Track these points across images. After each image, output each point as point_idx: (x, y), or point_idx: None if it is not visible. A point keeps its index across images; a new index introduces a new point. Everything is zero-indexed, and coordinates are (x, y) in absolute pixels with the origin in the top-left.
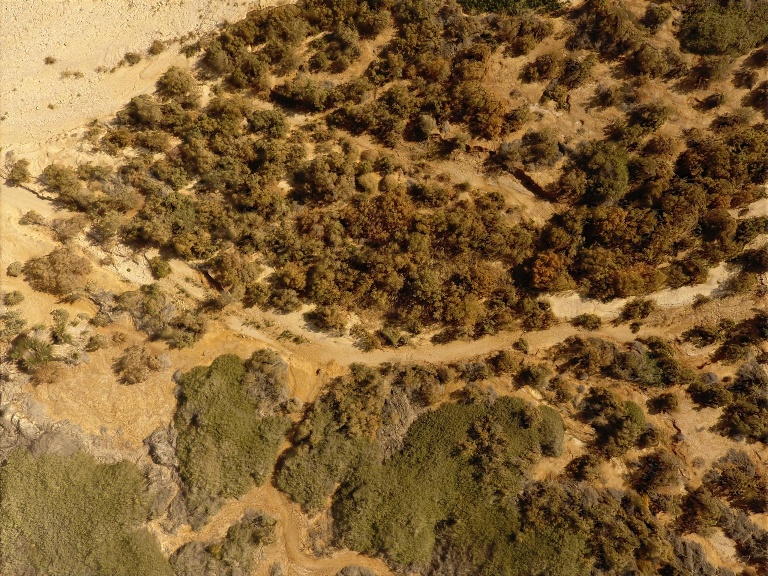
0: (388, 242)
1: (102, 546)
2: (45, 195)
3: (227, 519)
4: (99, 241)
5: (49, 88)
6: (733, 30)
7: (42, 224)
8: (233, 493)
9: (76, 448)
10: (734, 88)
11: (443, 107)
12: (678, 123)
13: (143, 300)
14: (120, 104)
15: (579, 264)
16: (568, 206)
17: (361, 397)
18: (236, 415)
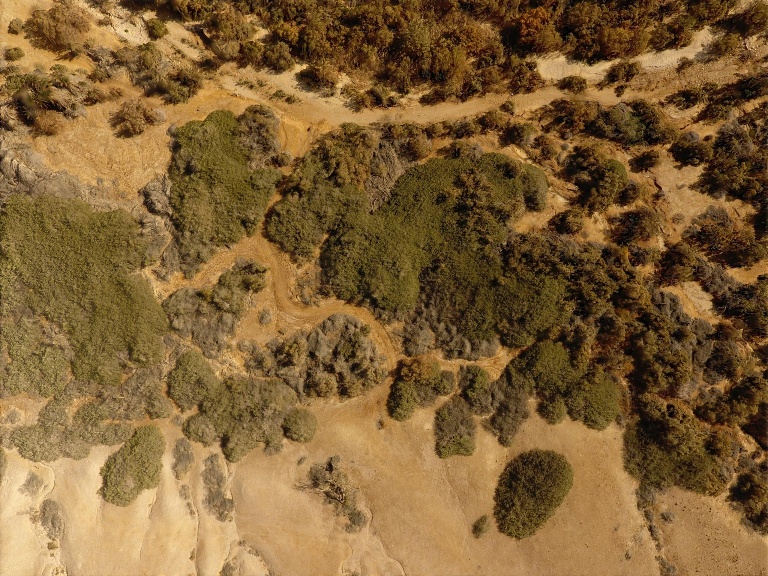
0: None
1: (97, 287)
2: None
3: (218, 268)
4: (98, 3)
5: None
6: None
7: None
8: (224, 240)
9: (73, 195)
10: None
11: None
12: None
13: (140, 54)
14: None
15: (566, 19)
16: None
17: (350, 147)
18: (228, 162)
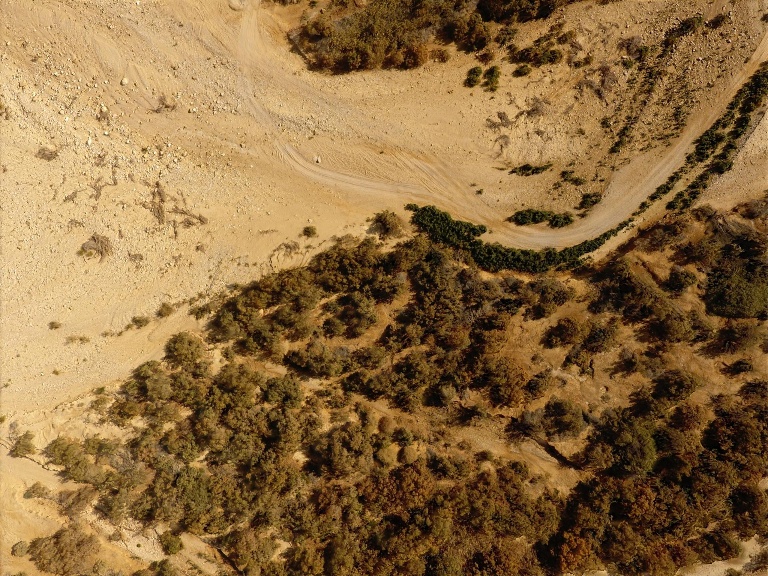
0: (409, 524)
1: None
2: (51, 468)
3: None
4: (107, 515)
5: (54, 354)
6: (761, 299)
7: (48, 498)
8: None
9: None
10: (762, 353)
11: (463, 379)
12: (705, 388)
13: None
14: (128, 369)
15: (607, 548)
16: (593, 474)
17: None
18: None
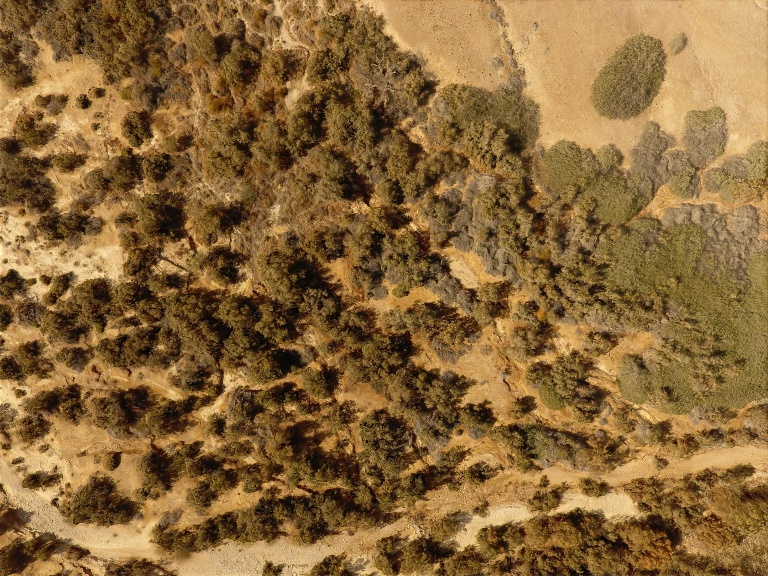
0: None
1: None
2: None
3: None
4: None
5: None
6: None
7: None
8: None
9: None
10: None
11: None
12: None
13: None
14: None
15: None
16: None
17: None
18: None
